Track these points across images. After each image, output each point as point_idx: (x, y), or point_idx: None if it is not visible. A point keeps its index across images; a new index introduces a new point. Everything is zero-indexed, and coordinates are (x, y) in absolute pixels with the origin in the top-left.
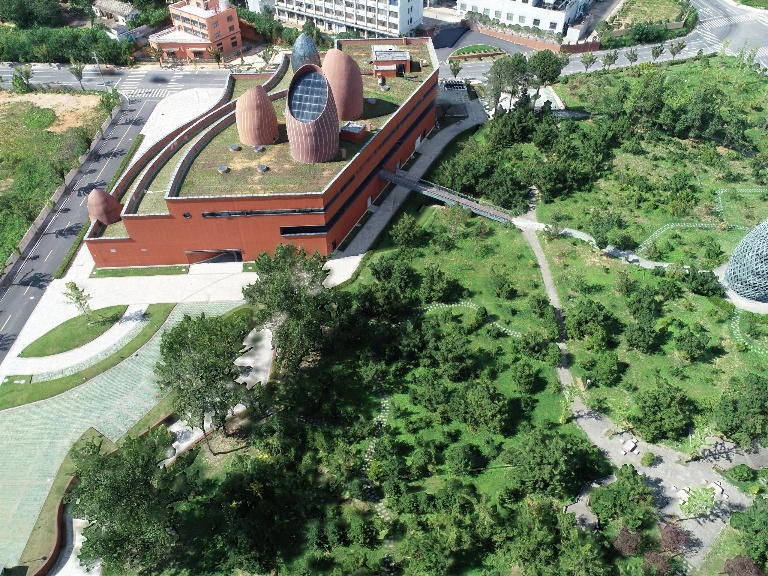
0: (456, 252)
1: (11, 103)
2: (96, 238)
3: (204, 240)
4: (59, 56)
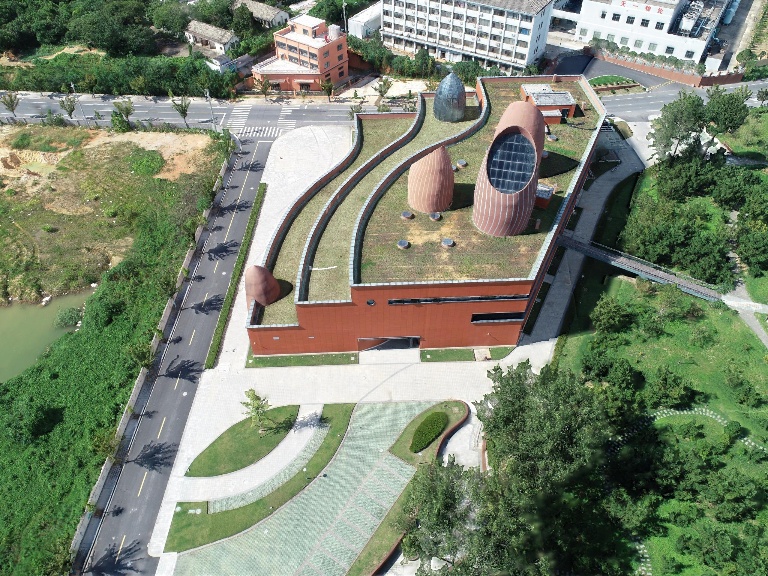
0: (667, 339)
1: (112, 144)
2: (260, 326)
3: (382, 327)
4: (156, 88)
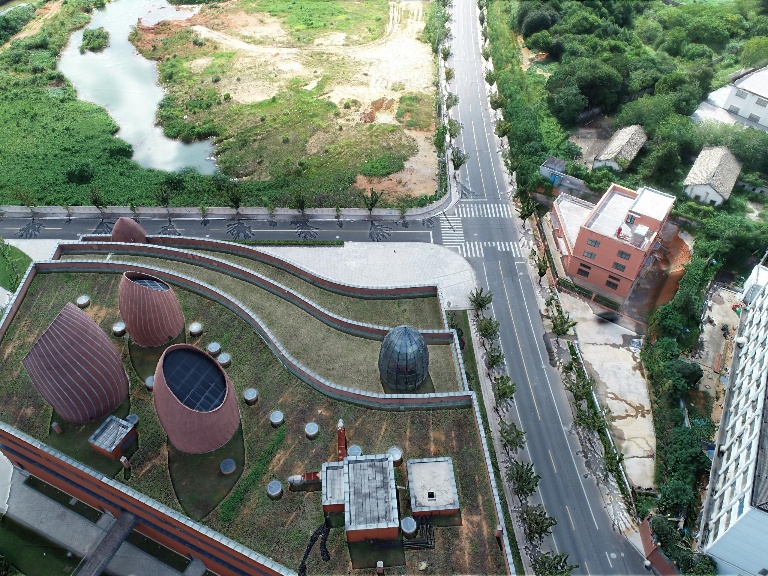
0: None
1: (413, 142)
2: None
3: None
4: None
